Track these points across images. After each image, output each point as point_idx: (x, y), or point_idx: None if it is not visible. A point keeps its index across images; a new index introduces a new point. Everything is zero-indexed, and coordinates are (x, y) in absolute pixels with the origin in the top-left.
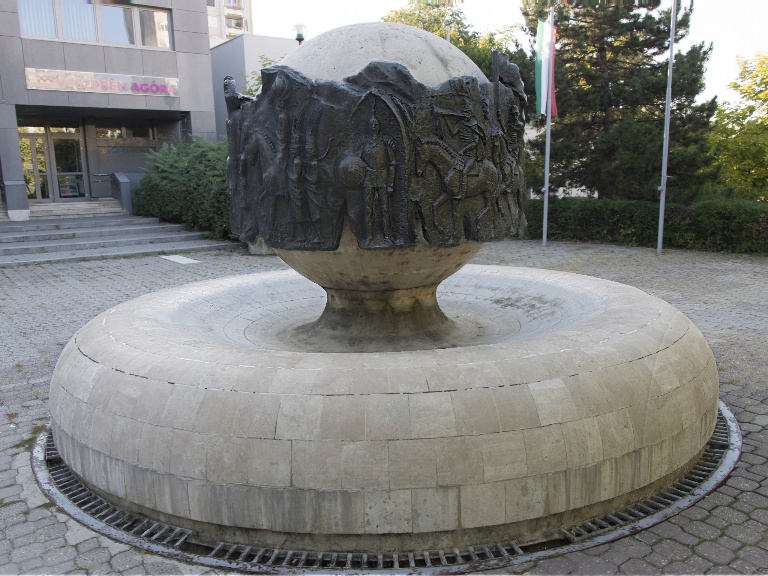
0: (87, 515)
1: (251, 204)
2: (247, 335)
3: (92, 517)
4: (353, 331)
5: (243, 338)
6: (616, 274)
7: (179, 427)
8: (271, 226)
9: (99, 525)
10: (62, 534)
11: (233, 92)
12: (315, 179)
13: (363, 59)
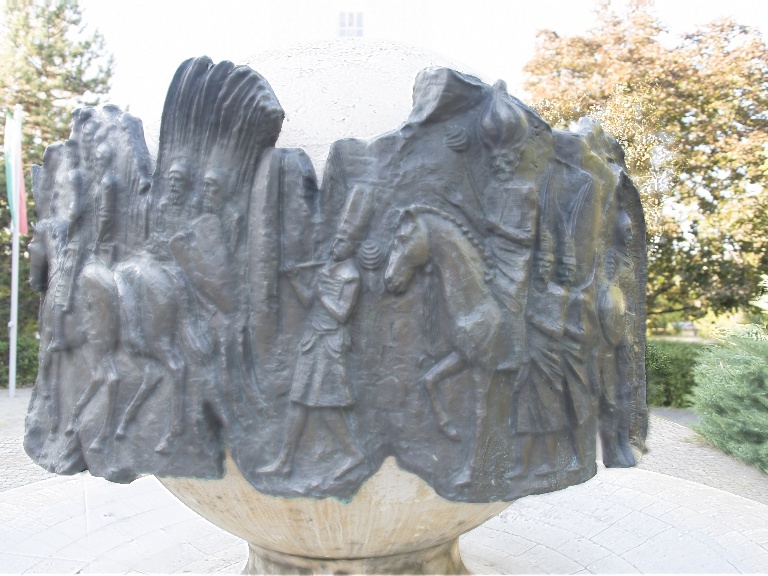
0: None
1: (367, 395)
2: None
3: None
4: None
5: None
6: None
7: None
8: (479, 448)
9: None
10: None
11: (277, 100)
12: (585, 331)
13: None
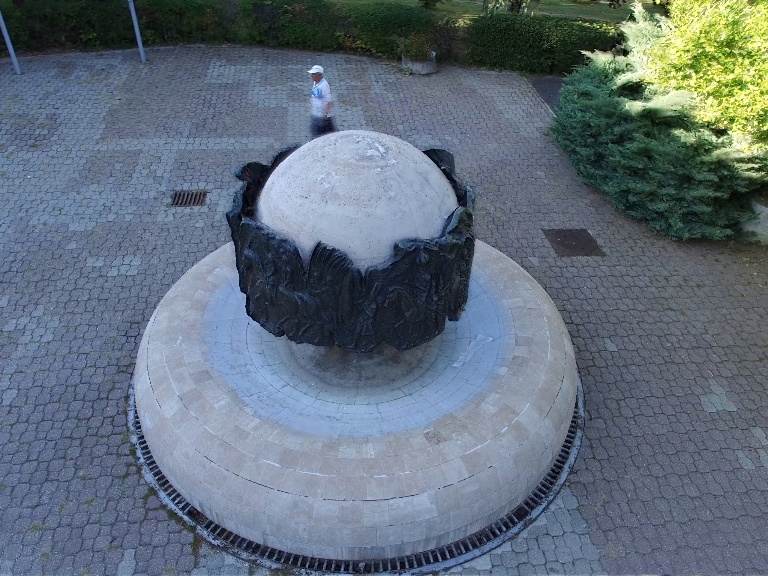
0: (461, 557)
1: None
2: (331, 401)
3: (464, 554)
4: (387, 353)
5: (344, 406)
6: (188, 121)
7: (512, 480)
8: None
9: (477, 552)
10: (477, 571)
11: (351, 261)
12: None
13: (435, 206)
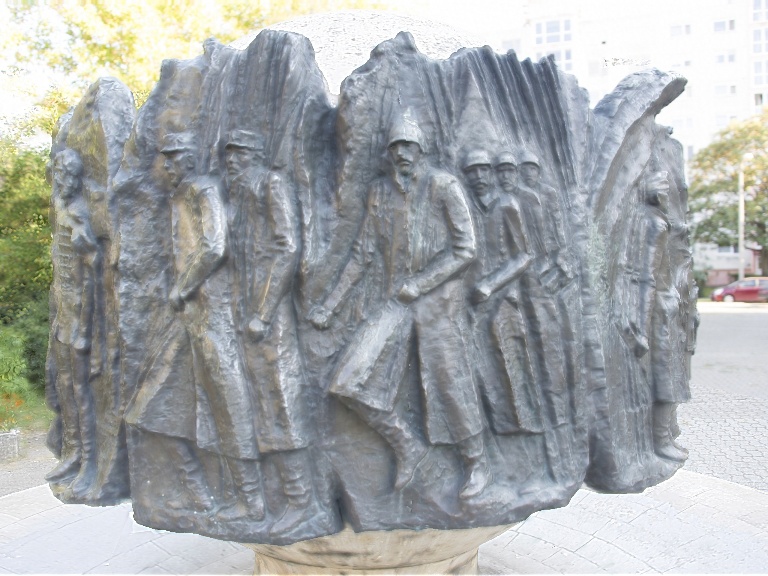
0: None
1: None
2: None
3: None
4: None
5: None
6: None
7: None
8: None
9: None
10: None
11: None
12: None
13: None
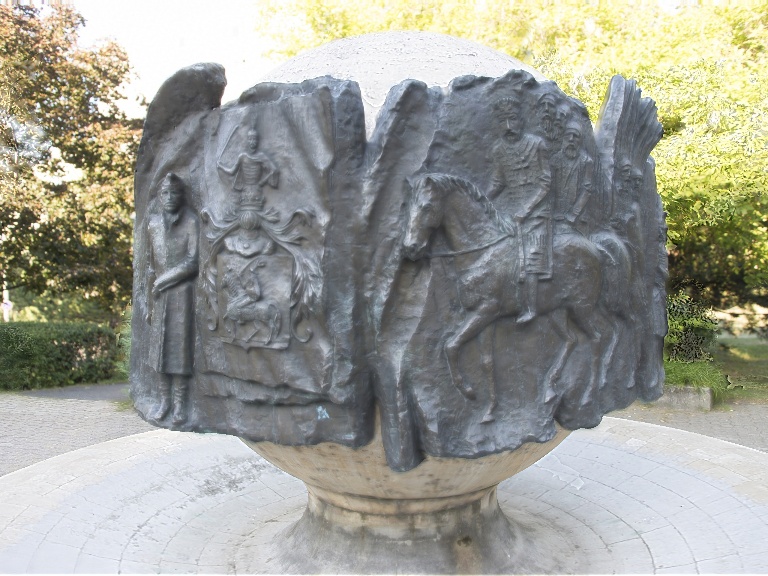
0: None
1: None
2: None
3: None
4: None
5: None
6: None
7: None
8: None
9: None
10: None
11: None
12: None
13: None
